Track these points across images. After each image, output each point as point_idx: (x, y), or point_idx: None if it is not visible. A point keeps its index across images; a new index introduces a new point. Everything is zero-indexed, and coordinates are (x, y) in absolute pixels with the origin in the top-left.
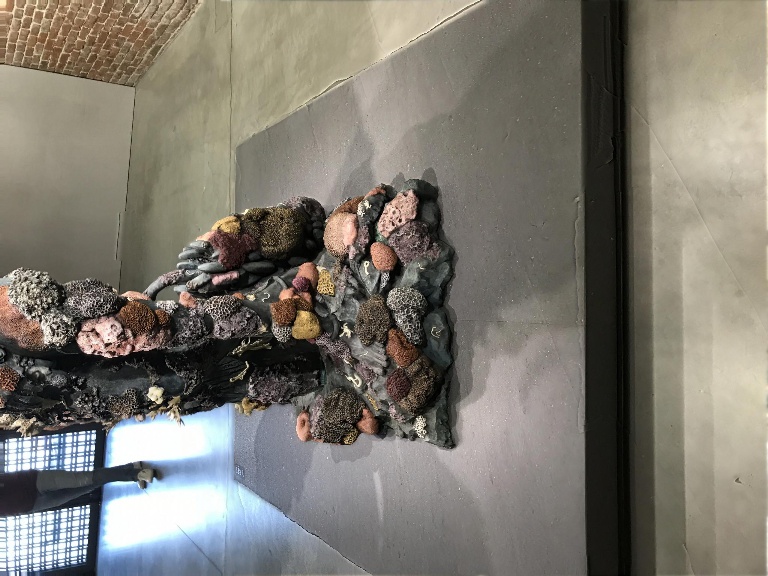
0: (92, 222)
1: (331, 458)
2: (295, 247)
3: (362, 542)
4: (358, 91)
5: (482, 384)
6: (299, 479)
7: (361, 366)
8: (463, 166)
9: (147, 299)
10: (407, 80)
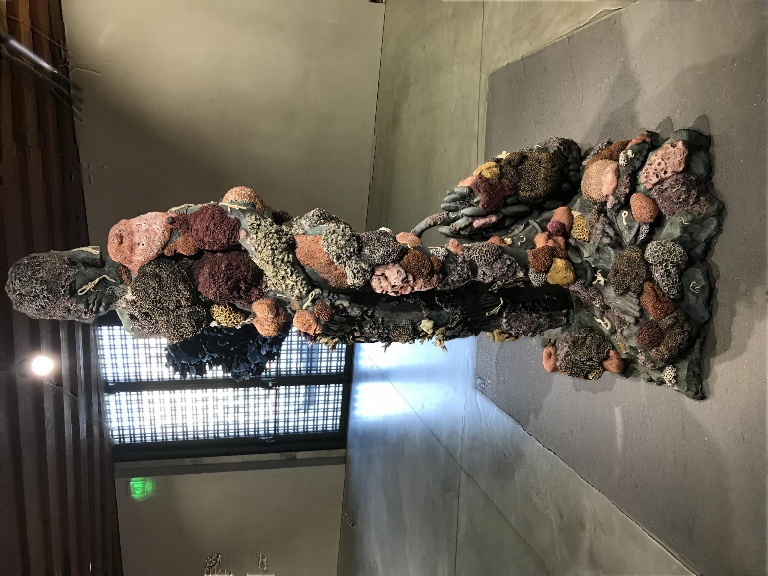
0: (353, 146)
1: (572, 386)
2: (551, 192)
3: (599, 467)
4: (626, 25)
5: (742, 344)
6: (538, 399)
7: (612, 312)
8: (743, 117)
9: (417, 239)
10: (684, 17)
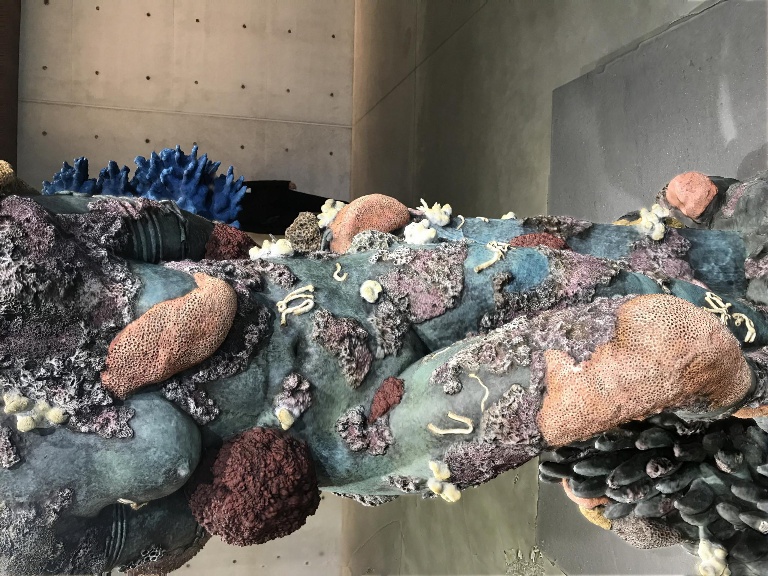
0: None
1: None
2: None
3: (762, 22)
4: None
5: None
6: None
7: None
8: None
9: None
10: None
